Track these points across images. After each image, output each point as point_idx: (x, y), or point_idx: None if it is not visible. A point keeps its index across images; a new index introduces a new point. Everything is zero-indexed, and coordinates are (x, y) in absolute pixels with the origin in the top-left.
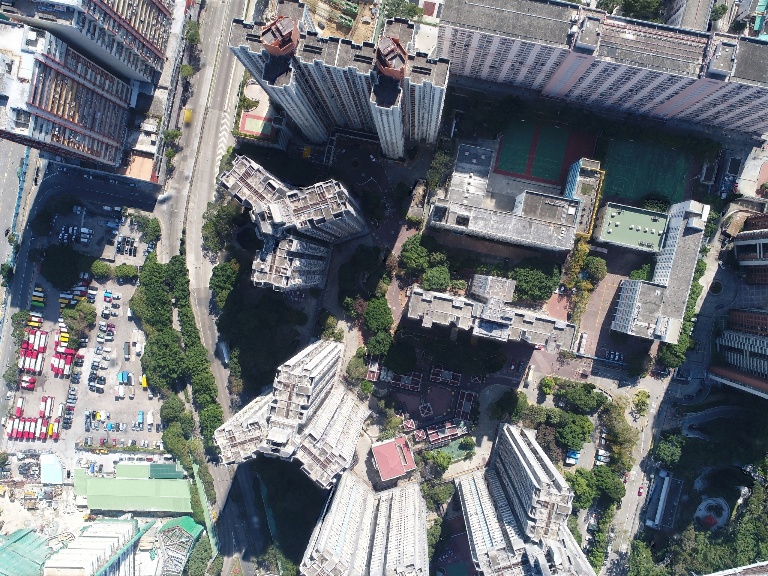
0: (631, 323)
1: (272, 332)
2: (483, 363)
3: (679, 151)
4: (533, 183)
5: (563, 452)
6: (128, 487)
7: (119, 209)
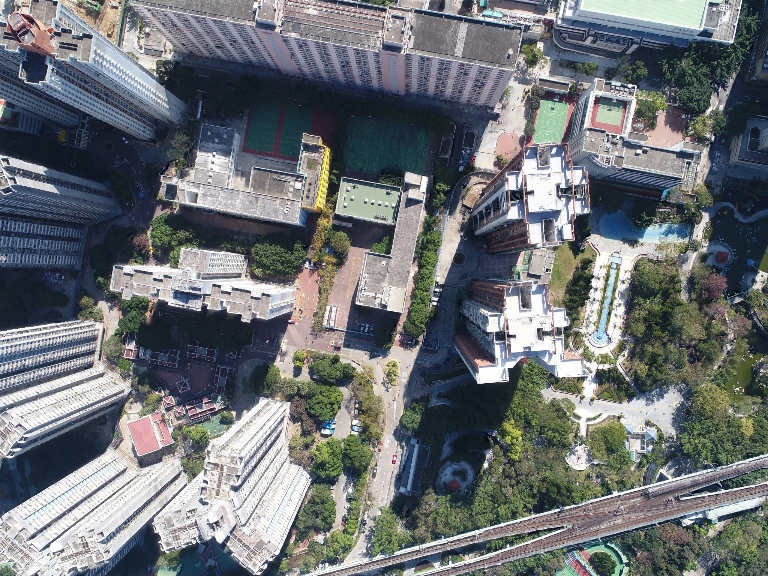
0: (359, 293)
1: (26, 313)
2: (231, 338)
3: (419, 126)
4: (281, 161)
5: (320, 423)
6: None
7: None
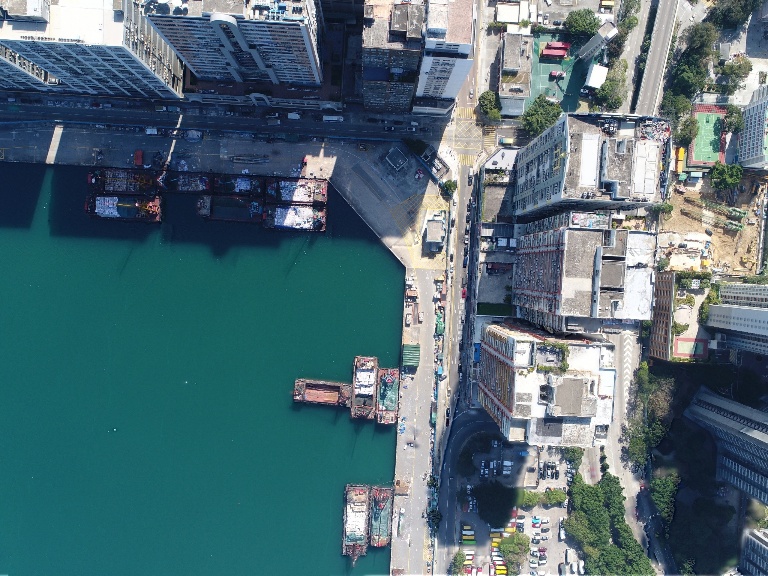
0: None
1: (717, 535)
2: None
3: None
4: None
5: None
6: None
7: None
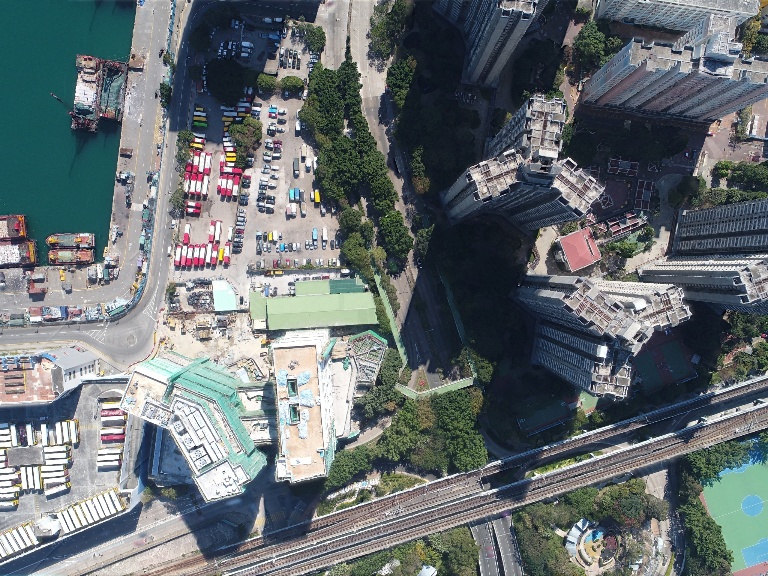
0: None
1: (452, 130)
2: (665, 146)
3: None
4: None
5: None
6: (310, 303)
7: (281, 20)
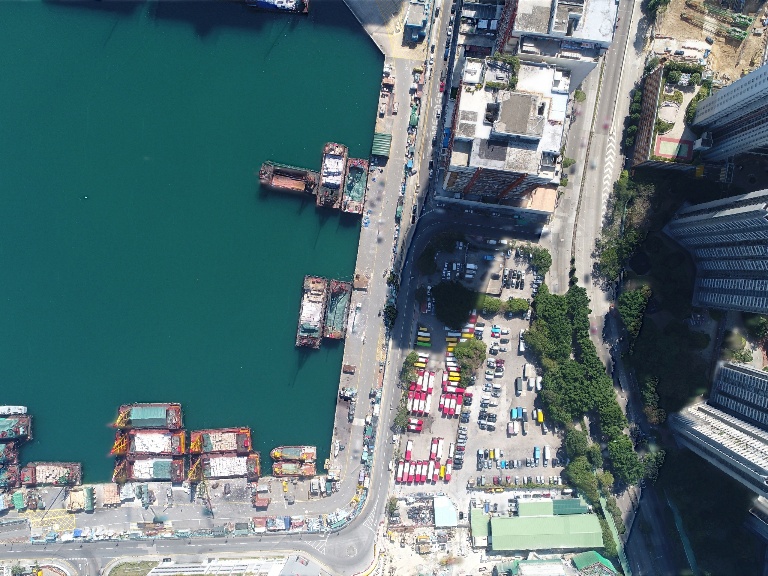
0: None
1: (686, 358)
2: None
3: None
4: None
5: None
6: (535, 525)
7: (506, 242)
